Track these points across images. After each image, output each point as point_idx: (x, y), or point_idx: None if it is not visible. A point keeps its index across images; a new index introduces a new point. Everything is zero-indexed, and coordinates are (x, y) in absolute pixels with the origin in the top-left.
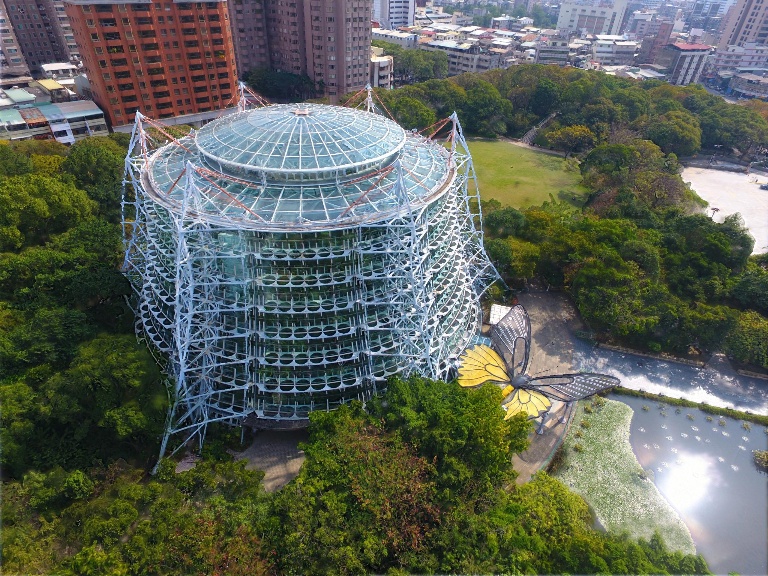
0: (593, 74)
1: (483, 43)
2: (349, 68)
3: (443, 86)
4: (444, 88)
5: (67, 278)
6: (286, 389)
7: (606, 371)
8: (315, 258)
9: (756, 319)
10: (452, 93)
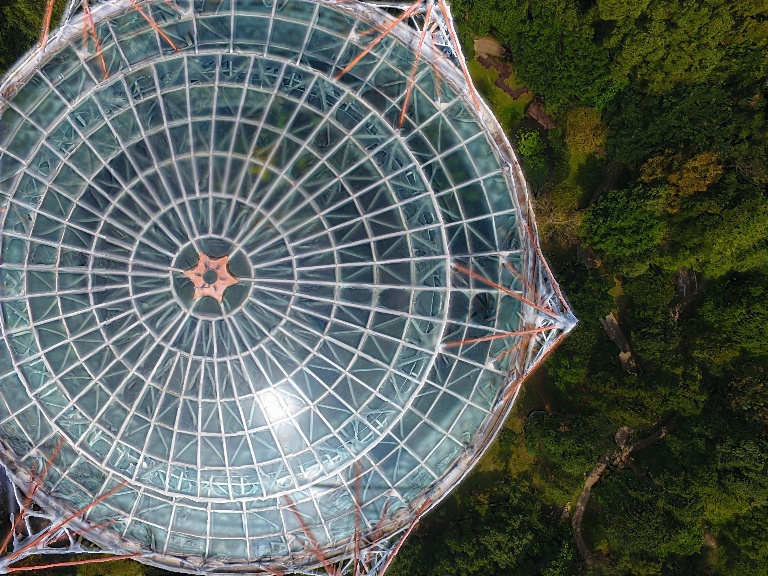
0: None
1: None
2: None
3: None
4: None
5: None
6: None
7: None
8: None
9: None
10: None
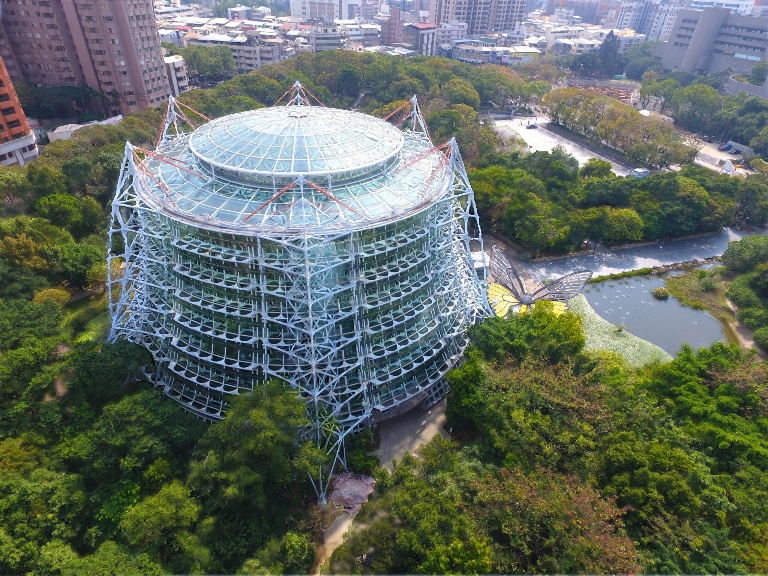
0: (378, 55)
1: (249, 35)
2: (145, 72)
3: (257, 80)
4: (259, 82)
5: (62, 372)
6: (397, 373)
7: (550, 276)
8: (411, 241)
9: (611, 210)
10: (270, 86)
